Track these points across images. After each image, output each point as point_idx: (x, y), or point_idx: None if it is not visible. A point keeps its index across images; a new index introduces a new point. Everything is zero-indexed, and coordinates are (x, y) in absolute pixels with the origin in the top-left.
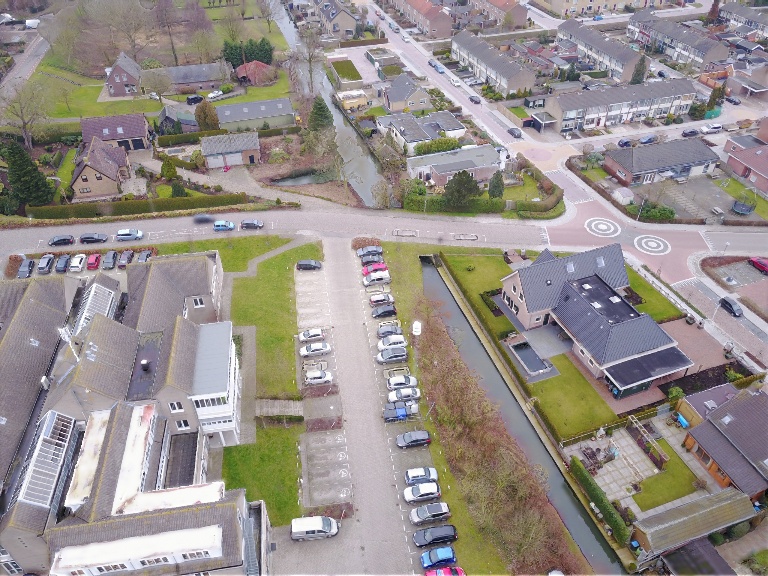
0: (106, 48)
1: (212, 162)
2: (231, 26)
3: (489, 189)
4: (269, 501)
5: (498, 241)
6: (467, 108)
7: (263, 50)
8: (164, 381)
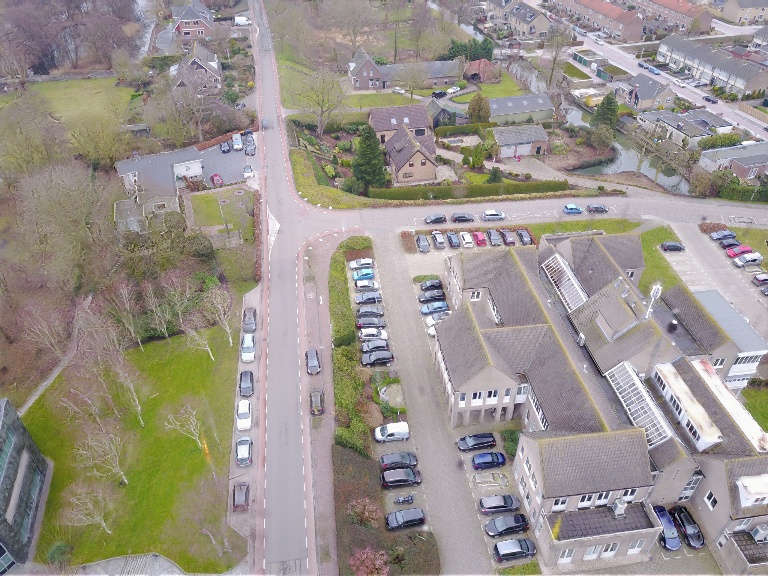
0: (313, 45)
1: (504, 152)
2: (443, 26)
3: None
4: None
5: None
6: (707, 107)
7: (486, 49)
8: (722, 338)
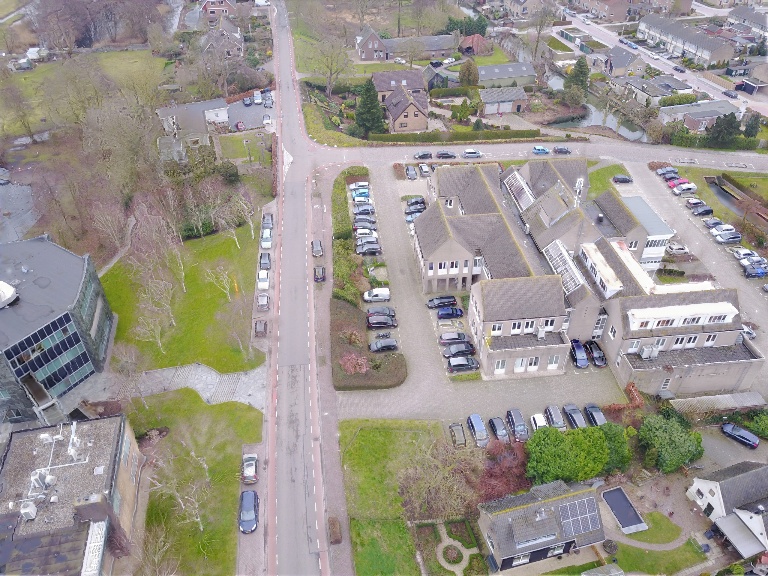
0: (325, 24)
1: (489, 109)
2: (442, 6)
3: (746, 130)
4: None
5: (764, 169)
6: (675, 76)
7: (480, 26)
8: (634, 223)
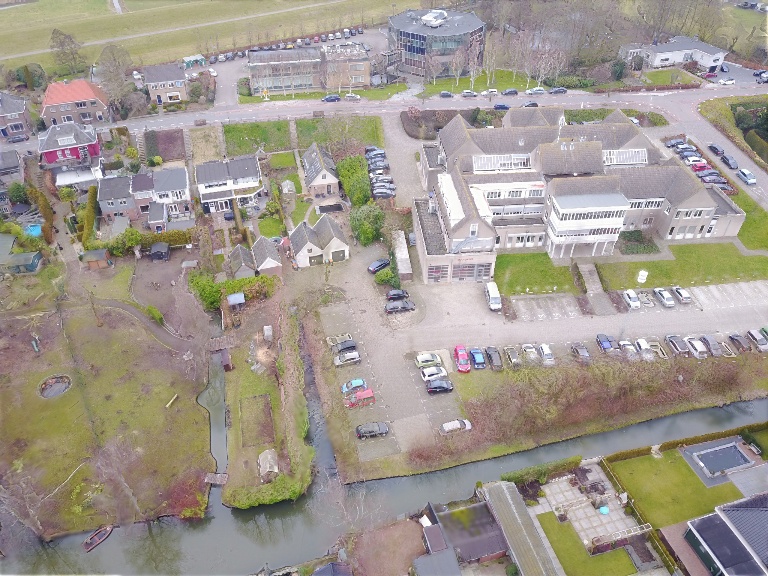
0: None
1: None
2: None
3: None
4: (511, 277)
5: None
6: None
7: None
8: None
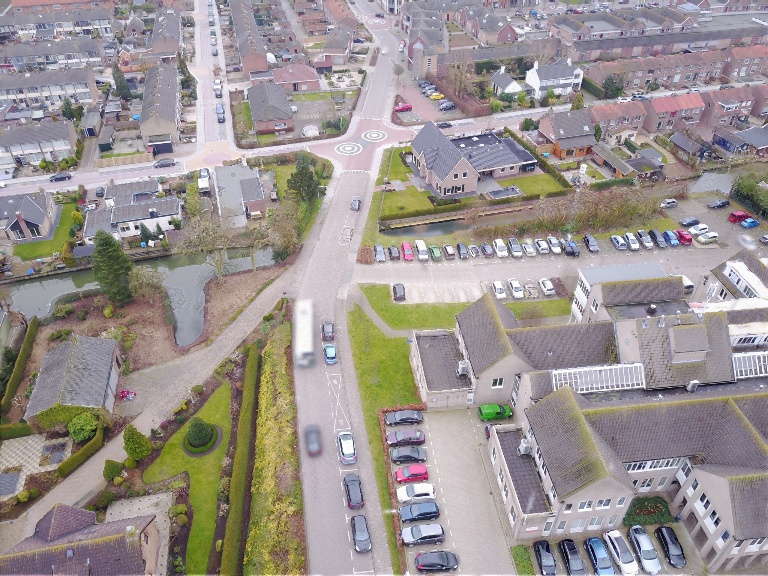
0: None
1: (108, 406)
2: None
3: None
4: None
5: (363, 192)
6: None
7: None
8: (677, 282)
